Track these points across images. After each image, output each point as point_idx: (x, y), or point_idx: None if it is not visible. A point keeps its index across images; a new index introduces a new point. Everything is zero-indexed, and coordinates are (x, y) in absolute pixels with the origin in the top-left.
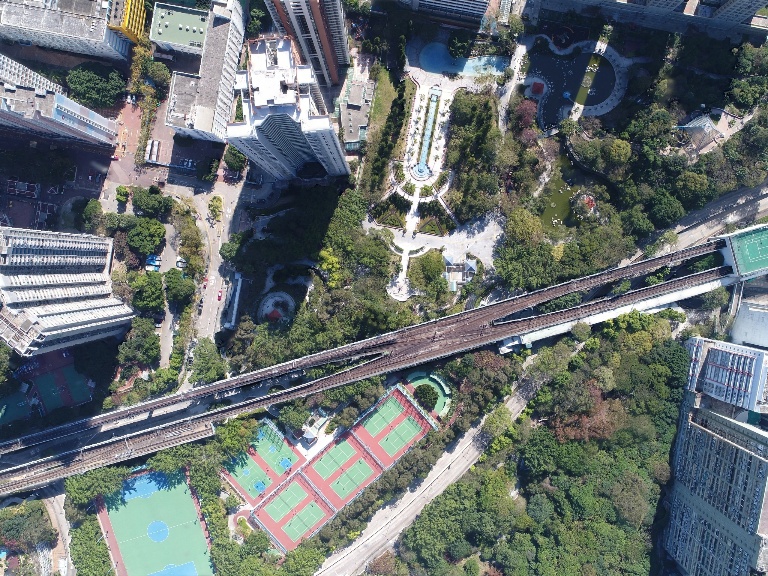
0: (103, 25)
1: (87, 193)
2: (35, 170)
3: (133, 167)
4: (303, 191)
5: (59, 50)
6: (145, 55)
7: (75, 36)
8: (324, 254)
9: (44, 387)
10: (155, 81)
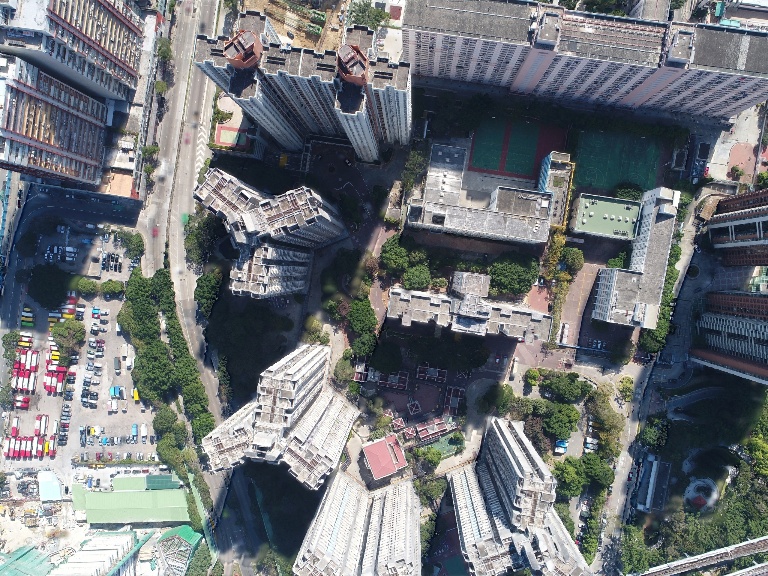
0: (547, 226)
1: (493, 375)
2: (456, 360)
3: (539, 349)
4: (731, 377)
5: (470, 237)
6: (563, 243)
7: (518, 237)
8: (762, 444)
9: (452, 569)
10: (572, 268)
